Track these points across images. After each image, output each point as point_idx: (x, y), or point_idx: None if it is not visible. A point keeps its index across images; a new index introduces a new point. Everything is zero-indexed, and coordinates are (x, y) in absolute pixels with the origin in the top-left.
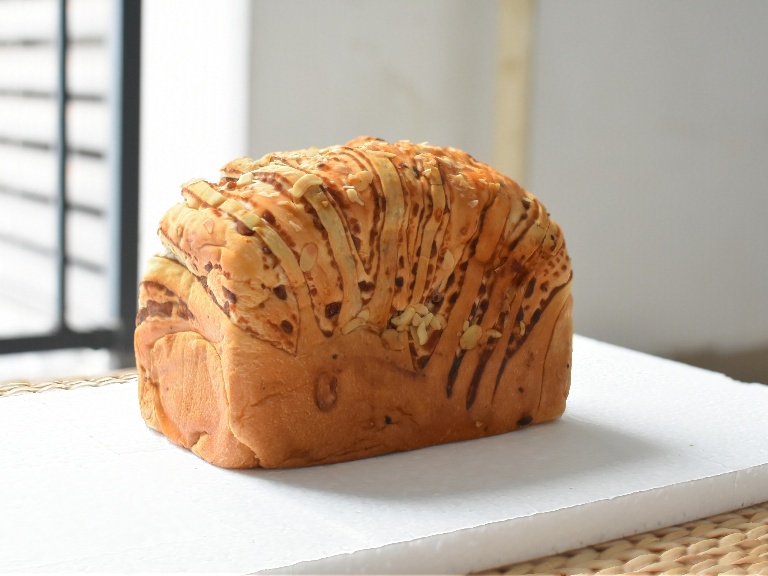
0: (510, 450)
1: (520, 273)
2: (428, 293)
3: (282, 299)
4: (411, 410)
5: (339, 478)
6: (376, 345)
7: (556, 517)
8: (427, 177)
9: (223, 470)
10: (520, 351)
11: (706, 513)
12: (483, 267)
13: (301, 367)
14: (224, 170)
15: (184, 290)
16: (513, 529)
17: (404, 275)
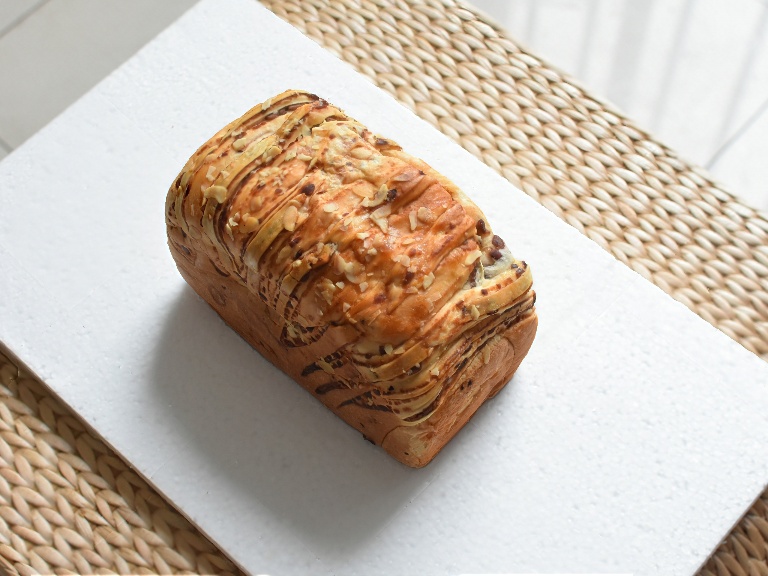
0: (304, 439)
1: None
2: None
3: (183, 235)
4: None
5: (195, 339)
6: (258, 307)
7: None
8: None
9: None
10: (364, 409)
11: None
12: None
13: (197, 273)
14: None
15: None
16: None
17: None
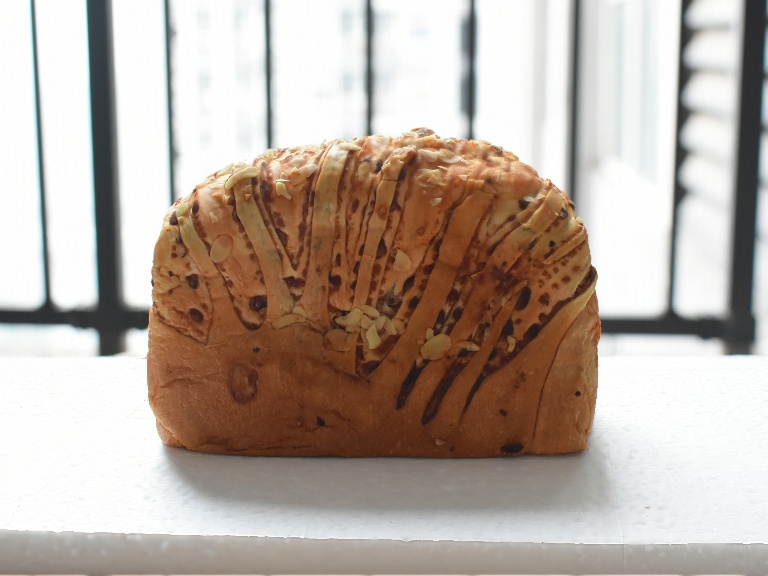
0: (443, 475)
1: (508, 282)
2: (379, 295)
3: (193, 288)
4: (350, 415)
5: (224, 469)
6: (313, 343)
7: (323, 546)
8: (382, 171)
9: (160, 445)
10: (505, 369)
11: None
12: (456, 272)
13: (212, 356)
14: None
15: None
16: (262, 548)
17: (341, 274)
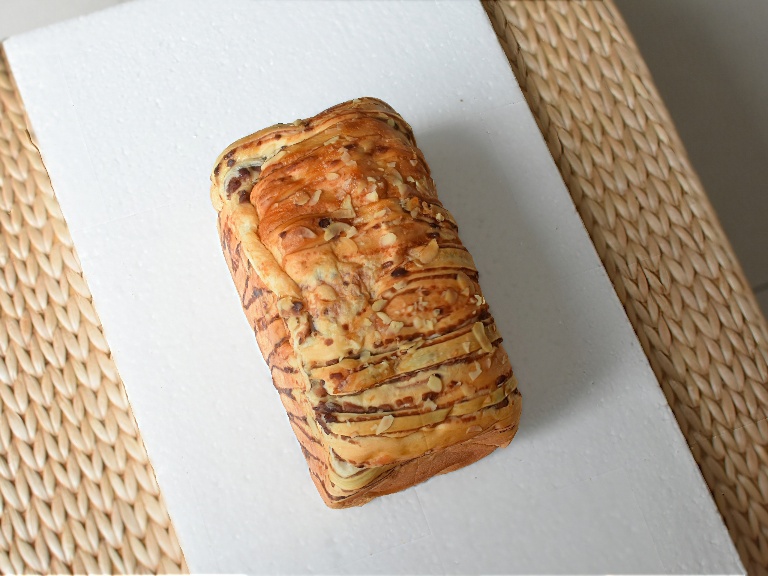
0: None
1: None
2: None
3: None
4: None
5: None
6: None
7: None
8: None
9: (482, 458)
10: None
11: None
12: None
13: None
14: None
15: None
16: None
17: None
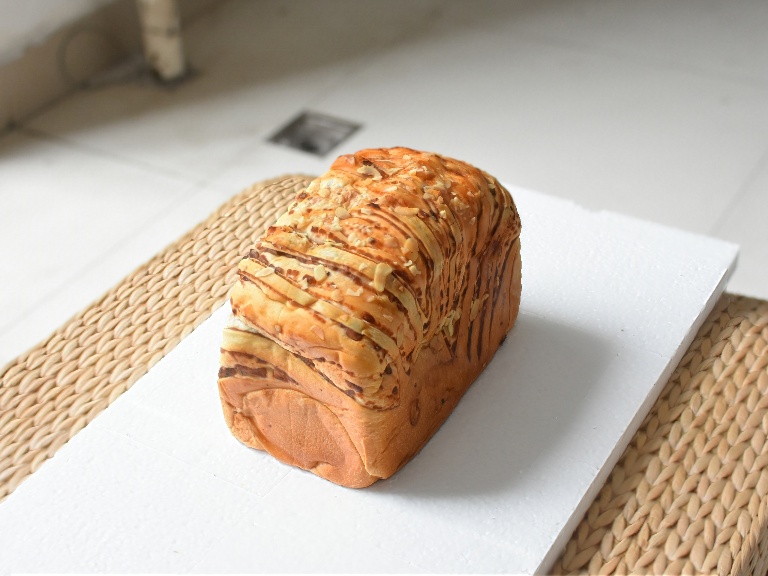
0: (516, 382)
1: None
2: None
3: (390, 374)
4: (453, 385)
5: (442, 472)
6: (430, 357)
7: (605, 466)
8: (445, 219)
9: (356, 491)
10: (499, 298)
11: (658, 395)
12: None
13: (403, 409)
14: (274, 246)
15: (280, 362)
16: None
17: (444, 302)
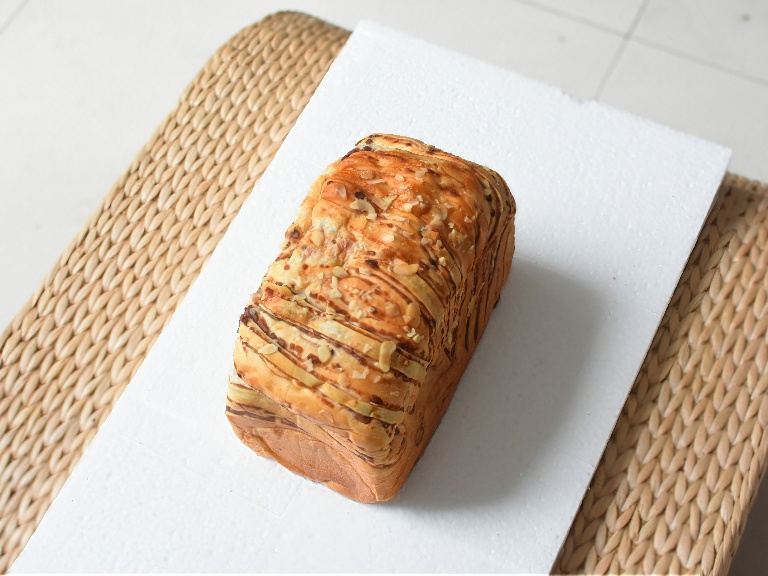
0: (511, 355)
1: None
2: None
3: (398, 434)
4: (452, 381)
5: (446, 478)
6: (432, 376)
7: None
8: (444, 266)
9: (367, 506)
10: None
11: (648, 350)
12: None
13: (410, 446)
14: None
15: (289, 416)
16: (585, 492)
17: None
